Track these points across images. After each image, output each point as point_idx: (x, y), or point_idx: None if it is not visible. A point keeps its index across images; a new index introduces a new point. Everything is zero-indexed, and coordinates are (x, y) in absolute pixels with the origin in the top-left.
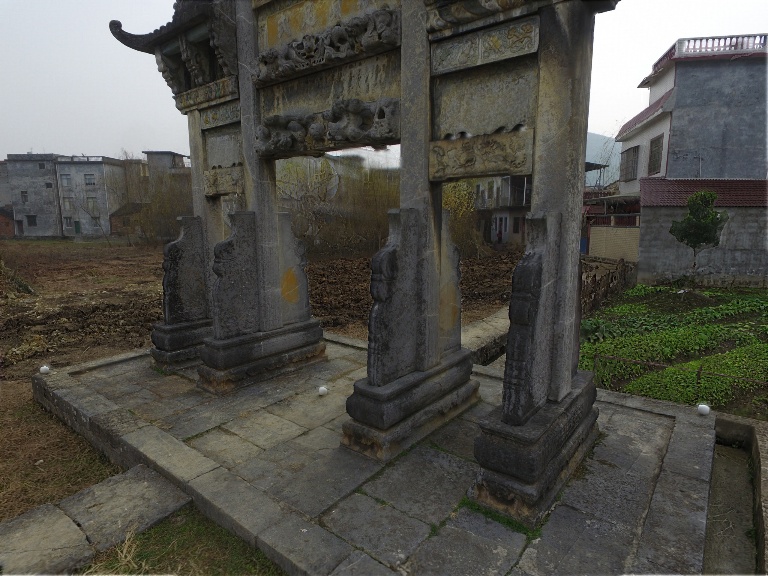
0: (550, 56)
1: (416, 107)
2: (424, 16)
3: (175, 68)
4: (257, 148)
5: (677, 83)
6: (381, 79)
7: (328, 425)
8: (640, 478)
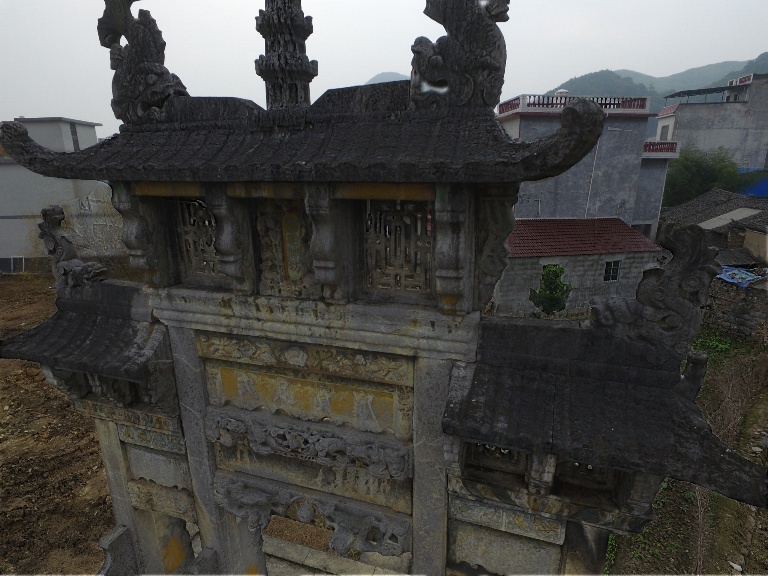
0: (576, 558)
1: (432, 539)
2: (443, 471)
3: (71, 374)
4: (219, 503)
5: (521, 135)
6: (385, 490)
7: None
8: None
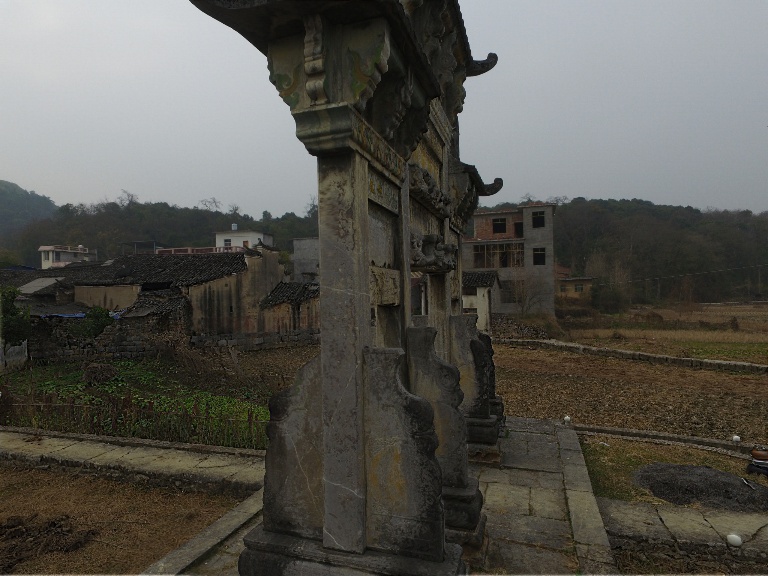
0: None
1: None
2: None
3: None
4: (420, 257)
5: None
6: None
7: None
8: None
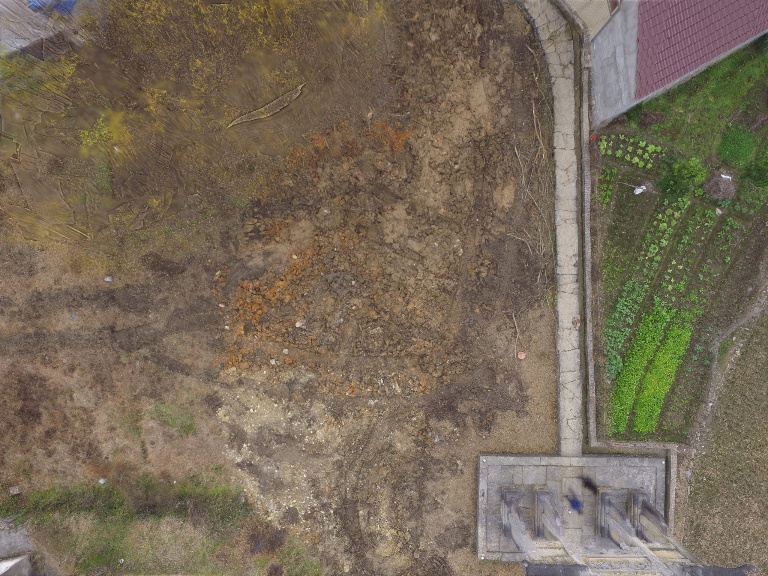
0: None
1: None
2: None
3: None
4: None
5: None
6: None
7: (583, 524)
8: (653, 503)
